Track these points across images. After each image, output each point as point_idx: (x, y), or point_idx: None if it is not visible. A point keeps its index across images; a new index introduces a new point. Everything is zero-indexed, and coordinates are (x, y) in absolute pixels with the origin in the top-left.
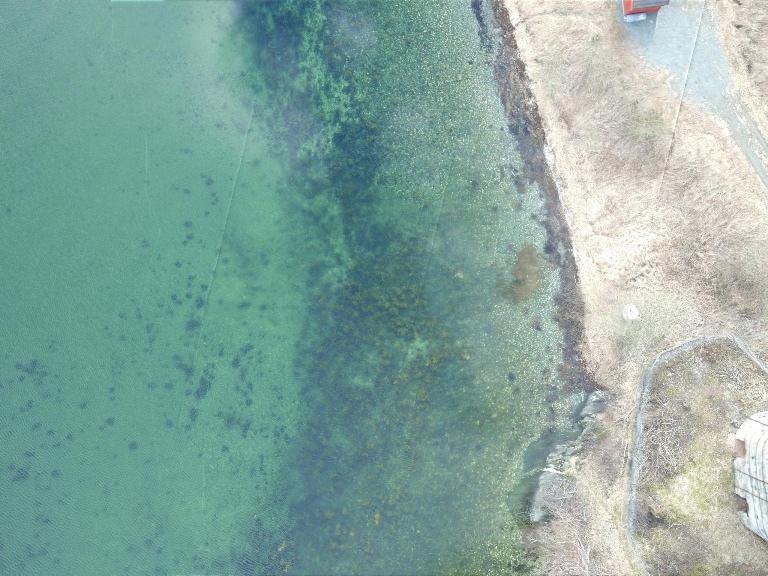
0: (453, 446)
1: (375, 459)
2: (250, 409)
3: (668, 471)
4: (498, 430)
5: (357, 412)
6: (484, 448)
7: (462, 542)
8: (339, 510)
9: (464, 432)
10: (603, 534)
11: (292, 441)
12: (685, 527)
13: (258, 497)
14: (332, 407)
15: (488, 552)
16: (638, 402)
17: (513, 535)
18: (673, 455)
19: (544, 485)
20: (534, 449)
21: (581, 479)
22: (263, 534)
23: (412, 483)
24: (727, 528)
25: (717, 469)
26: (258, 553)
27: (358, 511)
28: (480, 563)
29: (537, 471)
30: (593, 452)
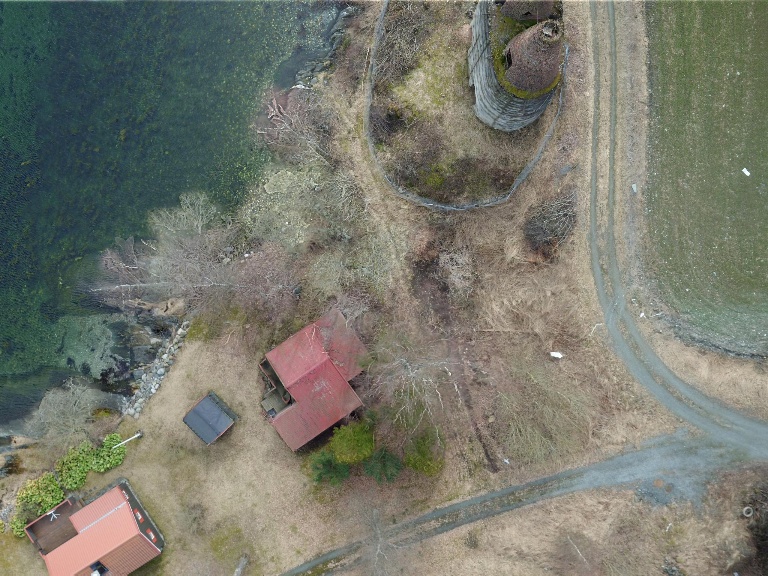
0: (203, 65)
1: (125, 79)
2: (0, 28)
3: (404, 67)
4: (249, 49)
5: (106, 29)
6: (234, 67)
7: (211, 163)
8: (85, 127)
9: (214, 51)
10: (345, 144)
11: (42, 62)
12: (420, 123)
13: (6, 116)
14: (82, 26)
15: (237, 173)
16: (384, 11)
17: (262, 156)
18: (409, 50)
19: (292, 101)
20: (284, 68)
21: (327, 92)
22: (9, 153)
23: (162, 104)
24: (462, 123)
25: (452, 62)
26: (3, 171)
27: (108, 134)
28: (228, 184)
29: (287, 90)
30: (340, 65)
